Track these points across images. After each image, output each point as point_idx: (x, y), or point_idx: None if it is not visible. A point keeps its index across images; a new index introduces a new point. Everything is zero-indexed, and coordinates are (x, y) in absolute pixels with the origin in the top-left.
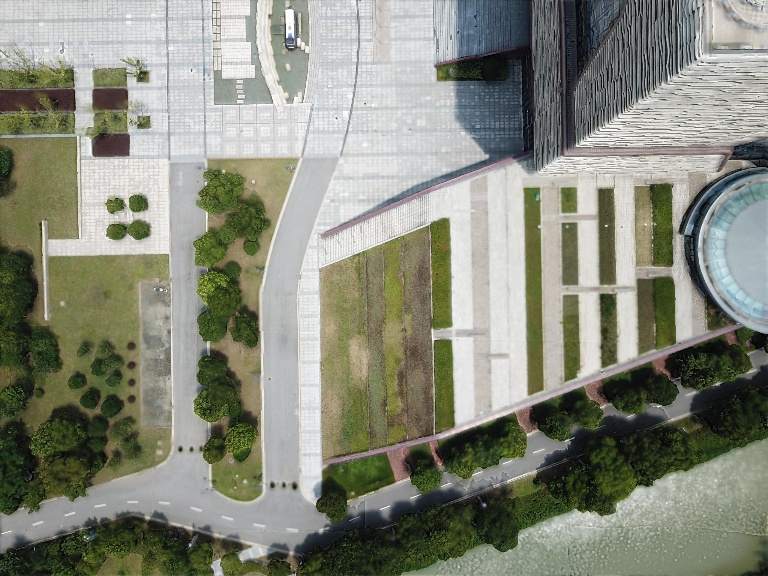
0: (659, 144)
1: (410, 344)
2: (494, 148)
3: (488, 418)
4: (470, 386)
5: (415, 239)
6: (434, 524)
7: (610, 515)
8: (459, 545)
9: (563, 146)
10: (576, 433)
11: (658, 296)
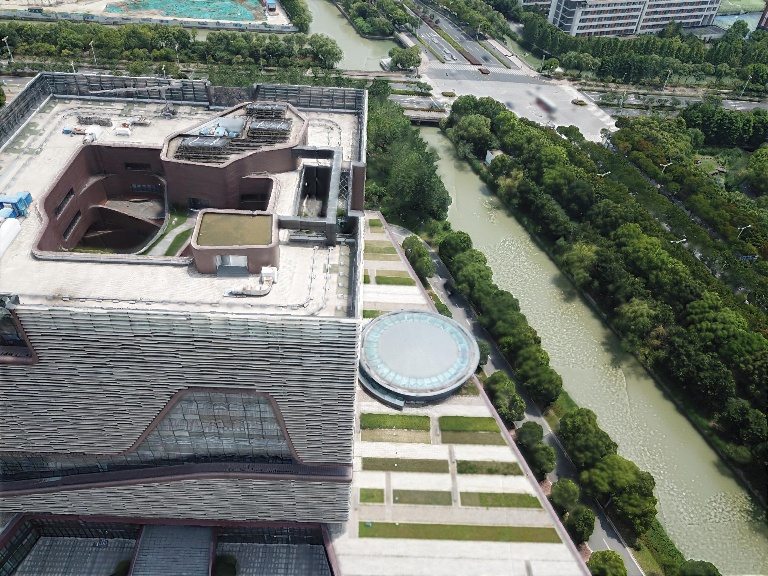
0: None
1: None
2: (305, 575)
3: None
4: None
5: None
6: None
7: None
8: None
9: (343, 480)
10: None
11: (456, 428)
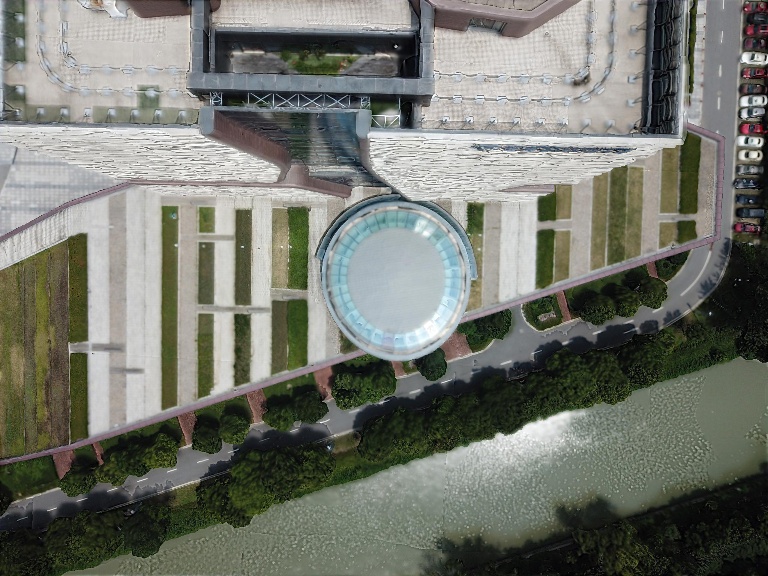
0: (193, 179)
1: (54, 355)
2: None
3: (121, 431)
4: (105, 399)
5: (58, 252)
6: (75, 529)
7: (284, 523)
8: (94, 550)
9: None
10: (240, 445)
11: (290, 318)
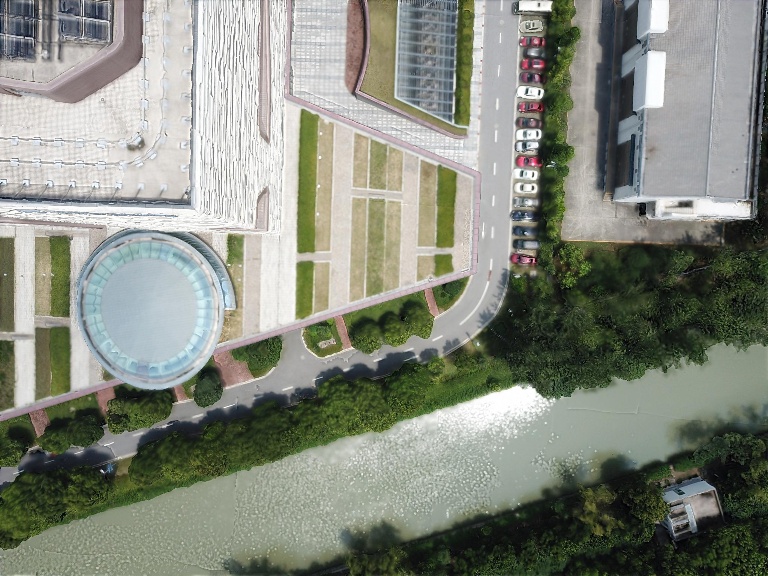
0: None
1: None
2: None
3: None
4: None
5: None
6: None
7: (78, 542)
8: None
9: None
10: (25, 466)
11: (52, 345)
